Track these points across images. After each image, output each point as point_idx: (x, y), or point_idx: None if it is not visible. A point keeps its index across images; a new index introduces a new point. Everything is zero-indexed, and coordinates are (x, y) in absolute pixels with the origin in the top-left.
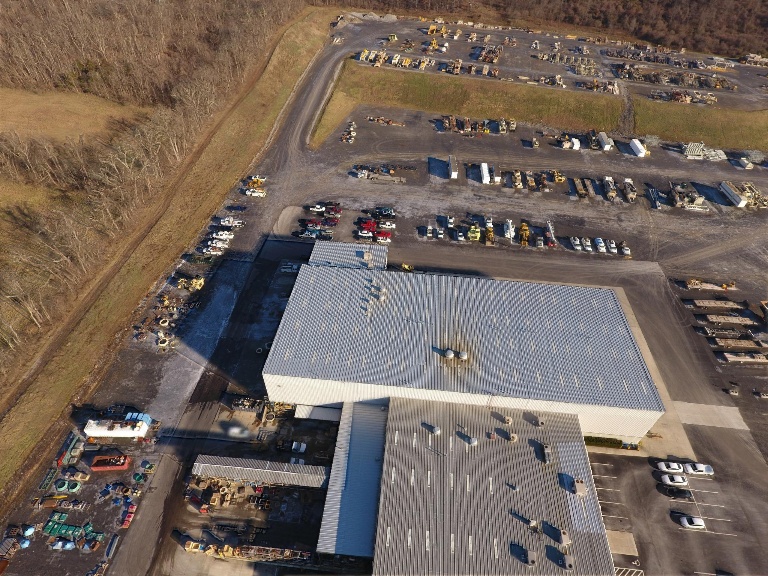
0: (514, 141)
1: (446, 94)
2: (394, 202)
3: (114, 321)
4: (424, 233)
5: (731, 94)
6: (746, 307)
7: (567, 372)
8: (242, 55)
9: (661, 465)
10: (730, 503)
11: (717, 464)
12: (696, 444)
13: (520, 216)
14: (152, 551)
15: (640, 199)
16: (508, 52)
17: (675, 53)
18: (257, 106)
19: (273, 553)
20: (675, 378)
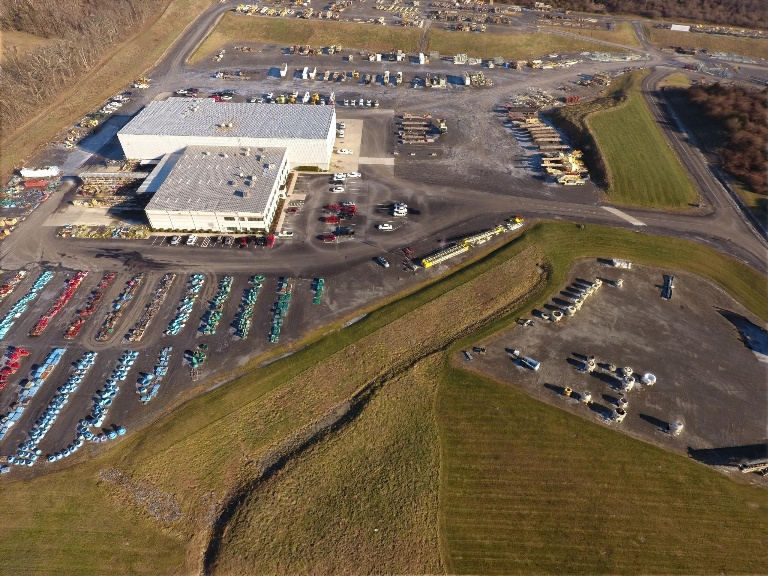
0: (337, 58)
1: (297, 32)
2: (237, 89)
3: (39, 140)
4: (250, 101)
5: (505, 26)
6: (430, 123)
7: (284, 130)
8: (140, 6)
9: (335, 174)
10: (363, 185)
11: (367, 175)
12: (361, 169)
13: (319, 93)
14: (56, 206)
15: (406, 84)
16: (356, 5)
17: (485, 4)
18: (151, 40)
19: (116, 199)
20: (367, 150)
